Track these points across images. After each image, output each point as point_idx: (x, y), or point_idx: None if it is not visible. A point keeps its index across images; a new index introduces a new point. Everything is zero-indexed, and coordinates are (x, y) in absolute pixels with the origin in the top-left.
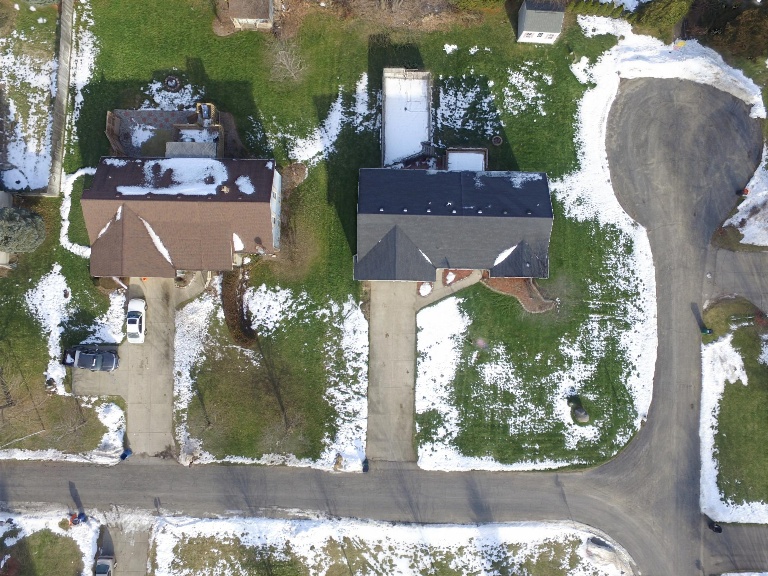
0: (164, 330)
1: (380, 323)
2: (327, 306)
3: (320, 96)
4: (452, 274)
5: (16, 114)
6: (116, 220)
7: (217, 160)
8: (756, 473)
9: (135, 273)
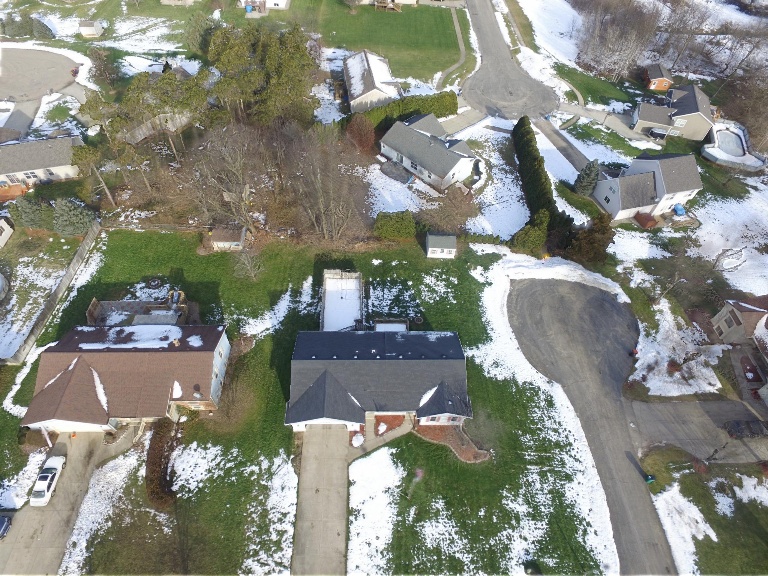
0: (75, 491)
1: (310, 477)
2: (257, 463)
3: (273, 290)
4: (384, 424)
5: (14, 305)
6: (68, 370)
7: (176, 326)
8: None
9: (67, 417)
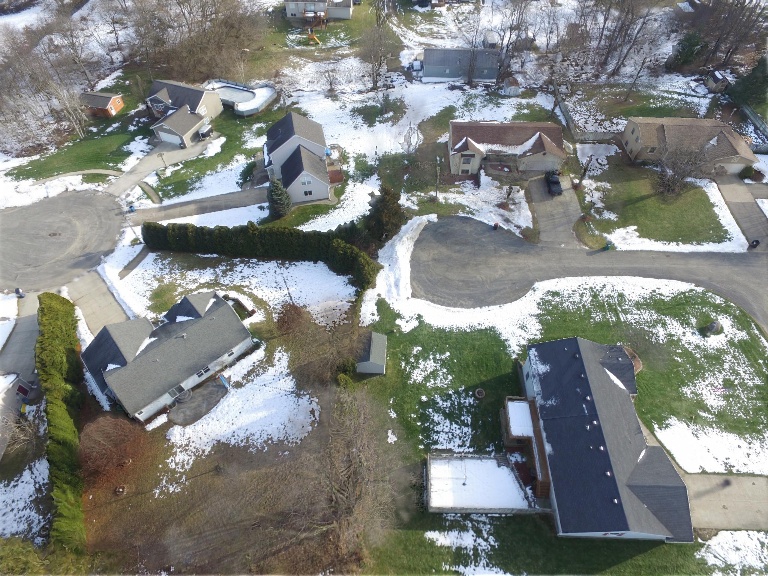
0: None
1: (715, 516)
2: None
3: None
4: None
5: None
6: None
7: None
8: (699, 222)
9: None
